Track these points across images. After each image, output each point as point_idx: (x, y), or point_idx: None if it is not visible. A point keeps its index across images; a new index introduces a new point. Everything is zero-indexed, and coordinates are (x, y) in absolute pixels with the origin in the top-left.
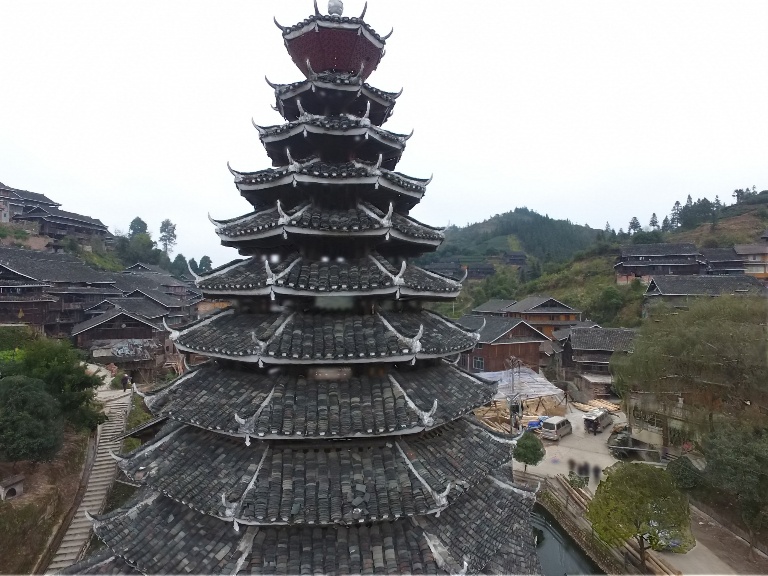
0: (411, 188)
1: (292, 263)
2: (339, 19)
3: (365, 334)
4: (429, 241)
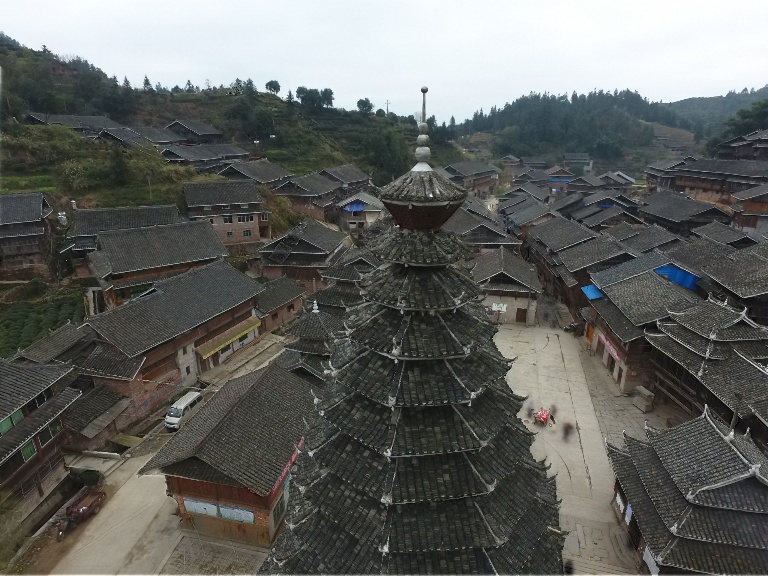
0: None
1: None
2: None
3: None
4: None
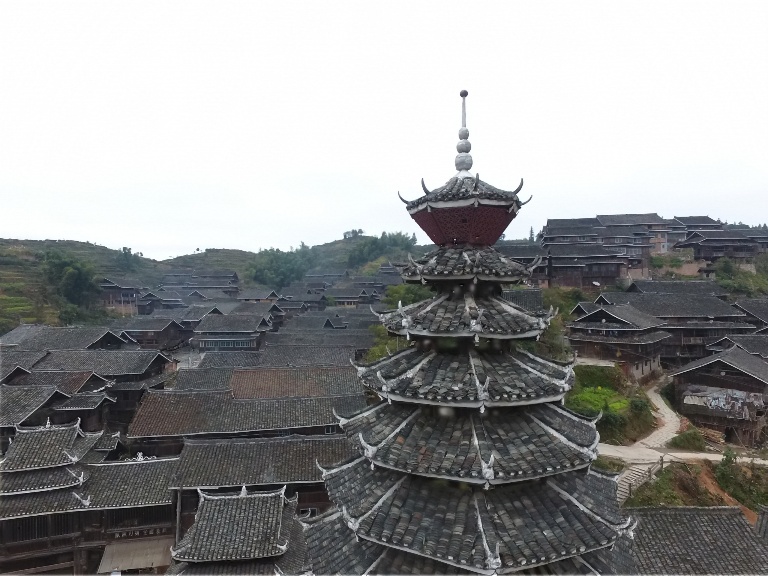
0: (446, 399)
1: (359, 459)
2: (418, 202)
3: (351, 561)
4: (455, 477)
